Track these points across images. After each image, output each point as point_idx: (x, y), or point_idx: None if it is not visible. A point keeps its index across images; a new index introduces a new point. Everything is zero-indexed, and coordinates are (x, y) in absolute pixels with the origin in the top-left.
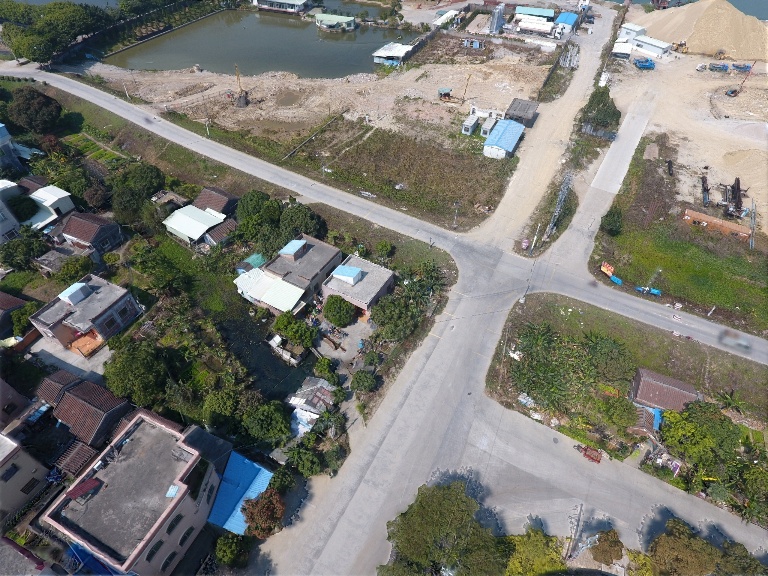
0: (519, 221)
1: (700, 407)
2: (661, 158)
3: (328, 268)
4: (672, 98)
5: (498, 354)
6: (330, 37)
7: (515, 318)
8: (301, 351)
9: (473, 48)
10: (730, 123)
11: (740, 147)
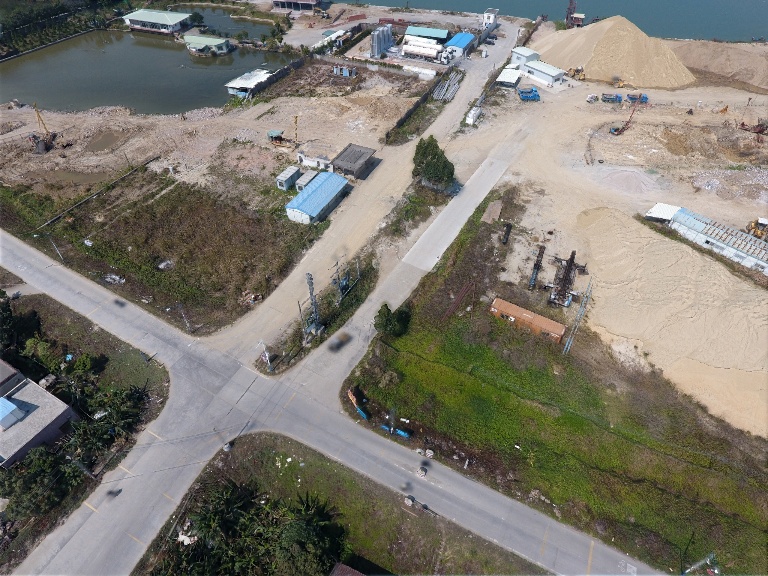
0: (288, 315)
1: None
2: (502, 219)
3: None
4: (546, 138)
5: (158, 539)
6: (200, 62)
7: (208, 475)
8: None
9: (343, 76)
10: (602, 170)
11: (603, 202)
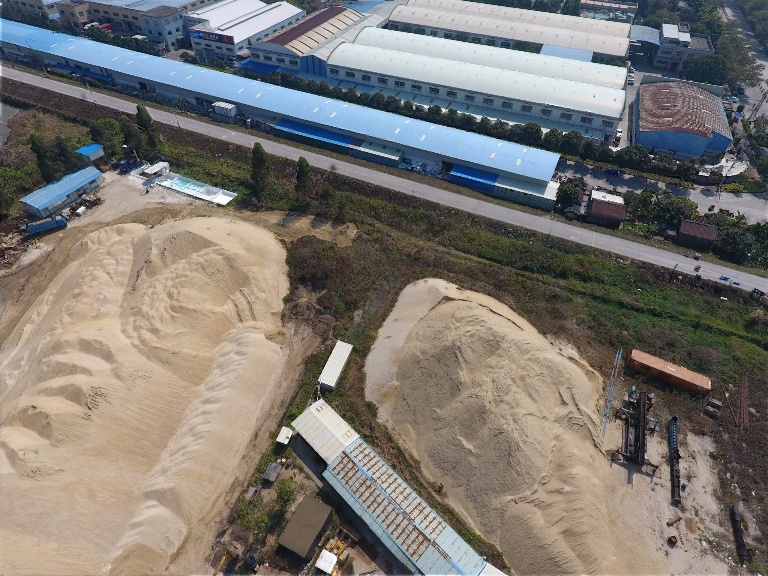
0: None
1: (685, 209)
2: None
3: None
4: None
5: None
6: None
7: None
8: None
9: None
10: None
11: None
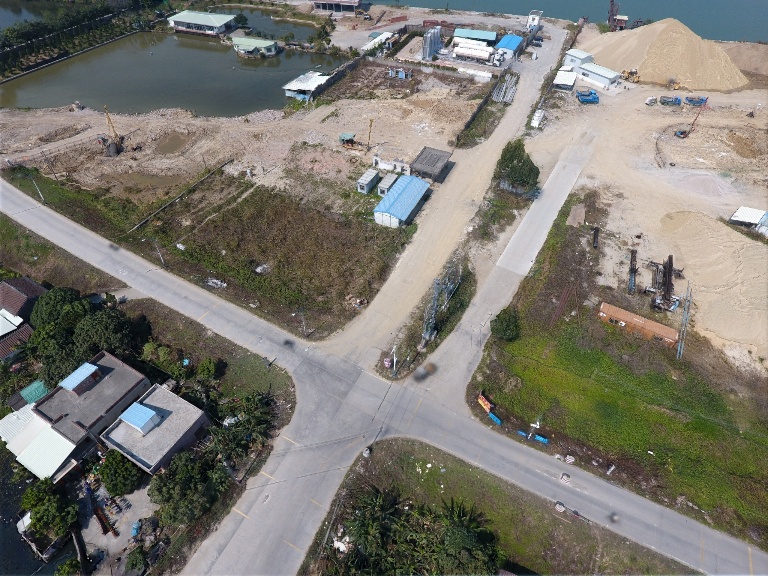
0: (396, 320)
1: None
2: (587, 223)
3: (124, 404)
4: (613, 140)
5: (316, 545)
6: (248, 63)
7: (352, 481)
8: (54, 540)
9: (399, 79)
10: (675, 173)
11: (683, 206)
